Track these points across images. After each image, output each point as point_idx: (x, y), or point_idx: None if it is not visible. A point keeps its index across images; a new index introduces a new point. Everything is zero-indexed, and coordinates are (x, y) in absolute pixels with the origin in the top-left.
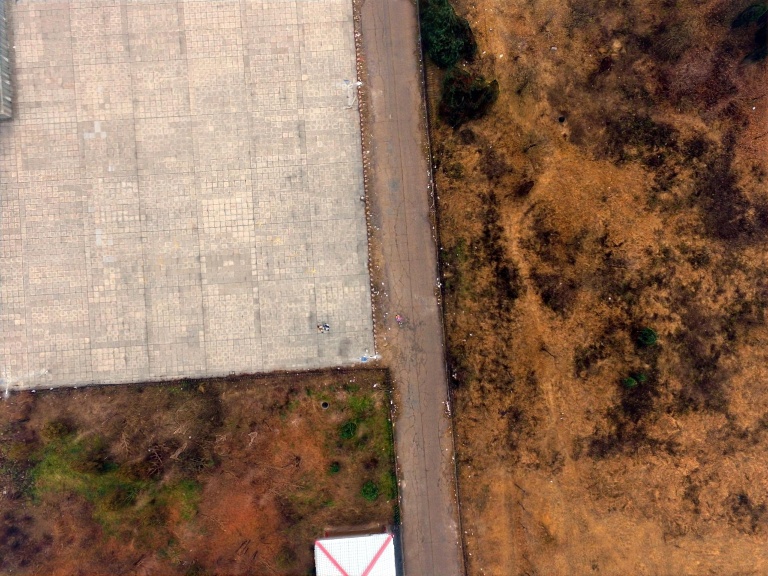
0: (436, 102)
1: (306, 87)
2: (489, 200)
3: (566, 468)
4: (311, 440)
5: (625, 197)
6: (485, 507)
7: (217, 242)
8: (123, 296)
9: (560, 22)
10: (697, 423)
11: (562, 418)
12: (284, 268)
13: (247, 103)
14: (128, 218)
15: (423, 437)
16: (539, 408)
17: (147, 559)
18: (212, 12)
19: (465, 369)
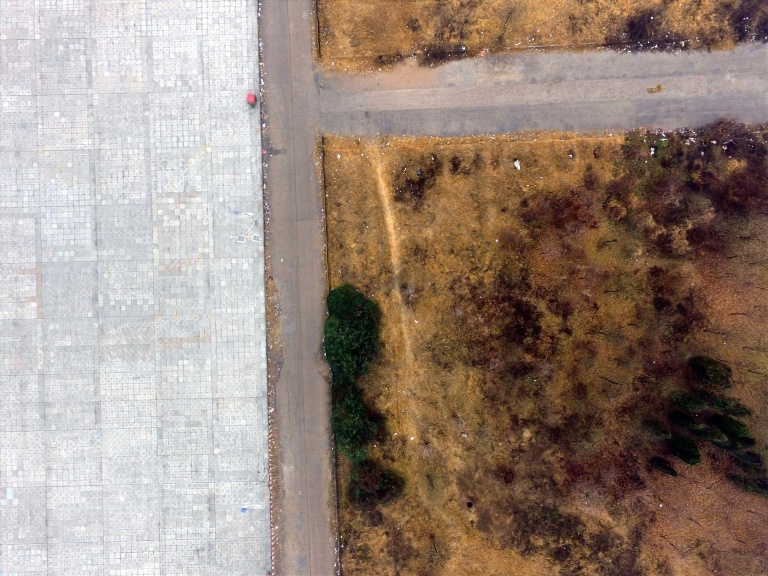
0: (346, 482)
1: (218, 461)
2: None
3: None
4: None
5: None
6: None
7: None
8: None
9: (471, 409)
10: None
11: None
12: None
13: (159, 475)
14: None
15: None
16: None
17: None
18: (128, 383)
19: None
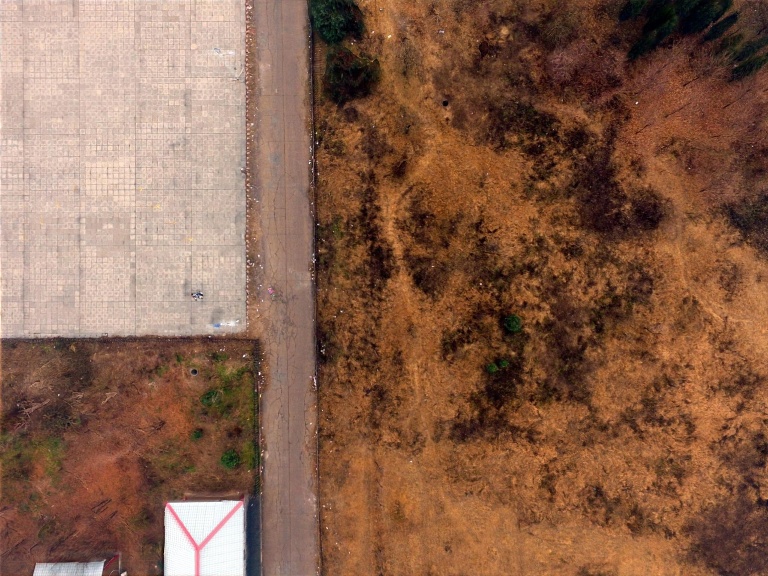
0: None
1: (195, 56)
2: (368, 179)
3: (427, 449)
4: (178, 405)
5: (502, 184)
6: (344, 482)
7: (98, 205)
8: (2, 252)
9: (450, 6)
10: (559, 413)
11: (426, 400)
12: (162, 234)
13: (135, 69)
14: (12, 176)
15: (288, 410)
16: (403, 388)
17: (8, 511)
18: None
19: (334, 345)
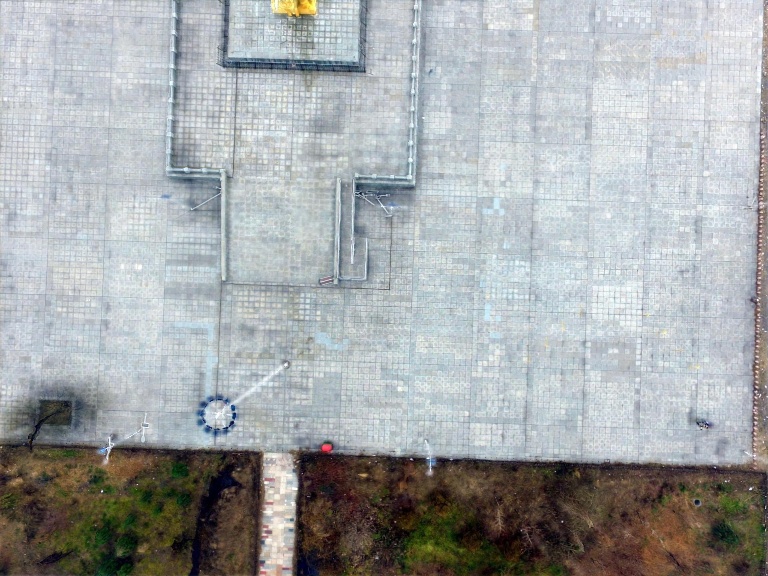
0: None
1: (707, 183)
2: None
3: None
4: (682, 537)
5: None
6: None
7: (604, 329)
8: (506, 373)
9: None
10: None
11: None
12: (668, 361)
13: (646, 194)
14: (518, 296)
15: None
16: None
17: None
18: (621, 101)
19: None
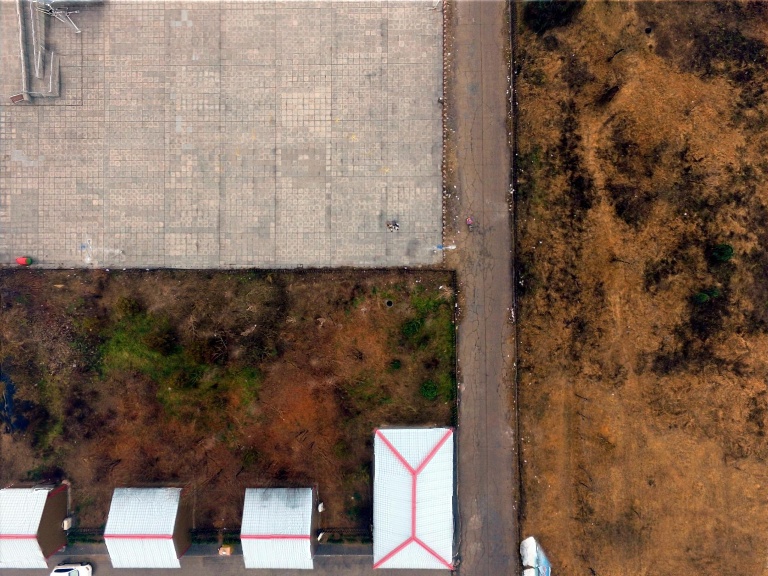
0: (521, 7)
1: None
2: (568, 108)
3: (629, 382)
4: (374, 337)
5: (709, 112)
6: (544, 415)
7: (293, 136)
8: (199, 183)
9: None
10: (767, 345)
11: (628, 331)
12: (358, 165)
13: None
14: (208, 107)
15: (485, 342)
16: (605, 320)
17: (207, 440)
18: None
19: (533, 276)
